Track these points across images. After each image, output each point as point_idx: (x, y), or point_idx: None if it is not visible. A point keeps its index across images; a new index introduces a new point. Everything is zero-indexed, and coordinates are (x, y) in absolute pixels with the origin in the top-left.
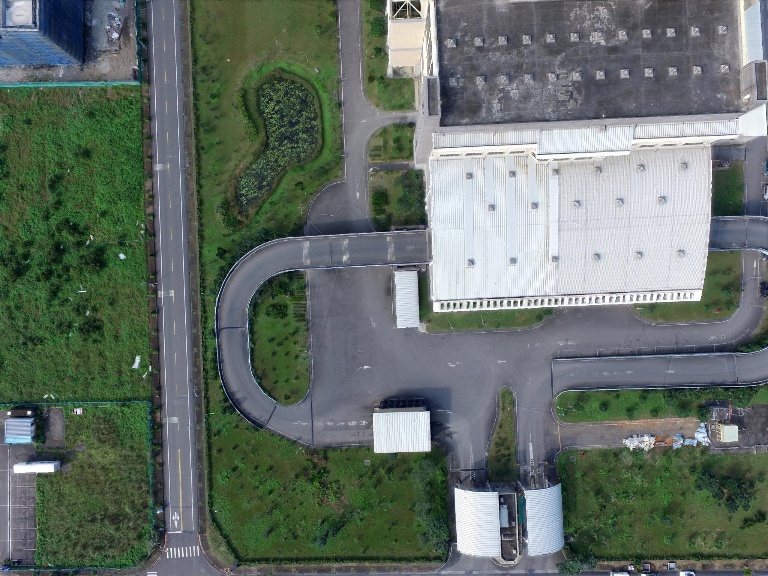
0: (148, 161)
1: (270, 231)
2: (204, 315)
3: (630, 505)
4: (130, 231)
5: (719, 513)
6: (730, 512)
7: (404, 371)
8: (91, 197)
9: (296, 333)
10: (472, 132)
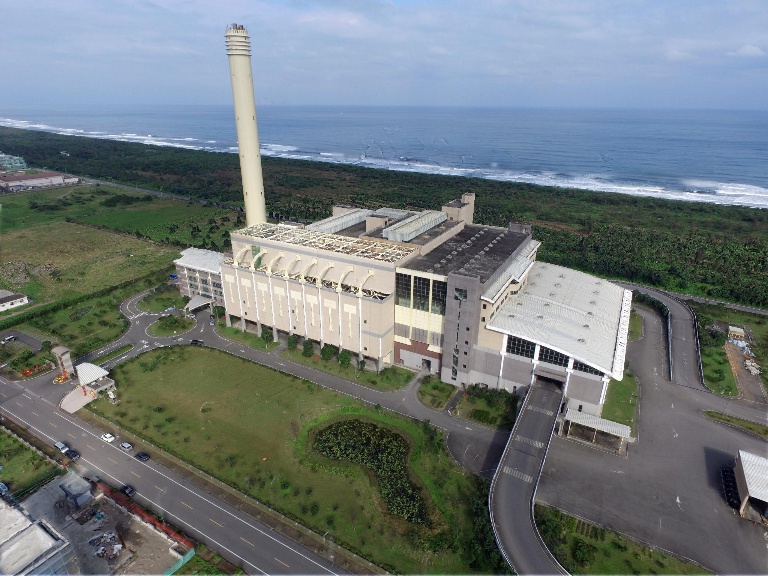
0: None
1: (470, 511)
2: None
3: None
4: None
5: None
6: None
7: (684, 471)
8: None
9: None
10: (490, 286)
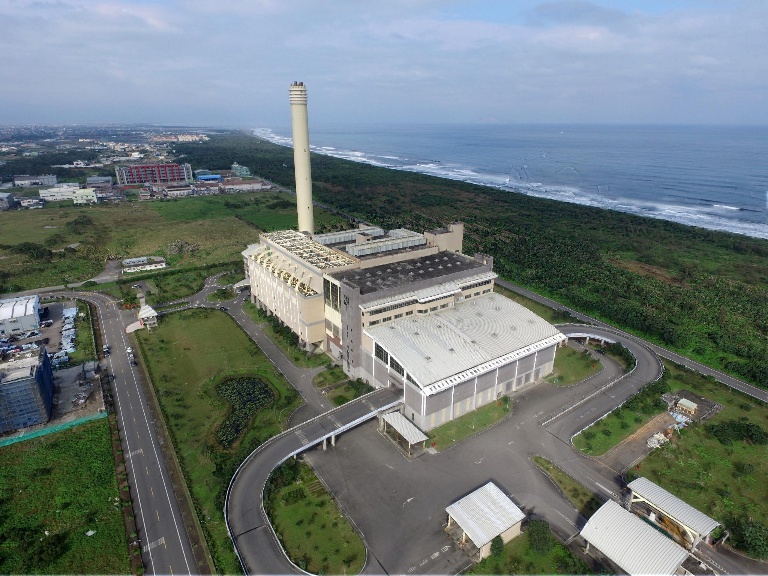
0: (119, 454)
1: None
2: (209, 540)
3: (716, 481)
4: (101, 508)
5: (766, 452)
6: (765, 442)
7: (445, 486)
8: (49, 500)
9: (323, 505)
10: (379, 300)
